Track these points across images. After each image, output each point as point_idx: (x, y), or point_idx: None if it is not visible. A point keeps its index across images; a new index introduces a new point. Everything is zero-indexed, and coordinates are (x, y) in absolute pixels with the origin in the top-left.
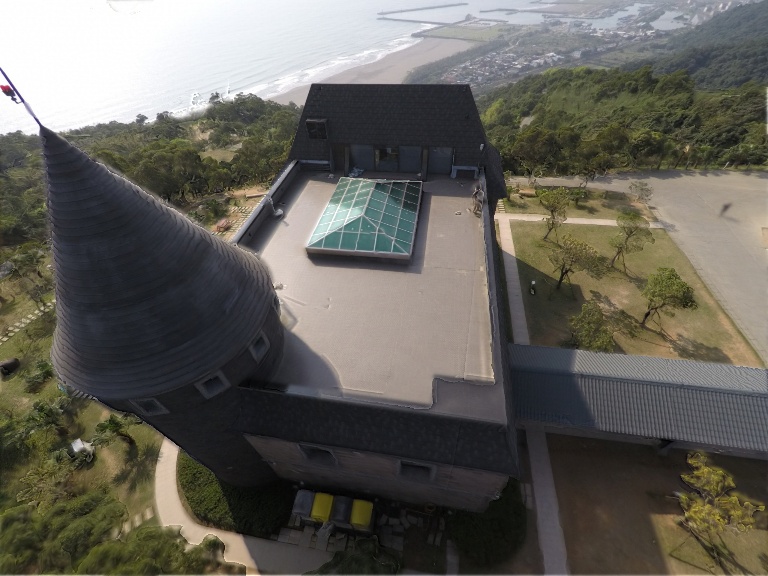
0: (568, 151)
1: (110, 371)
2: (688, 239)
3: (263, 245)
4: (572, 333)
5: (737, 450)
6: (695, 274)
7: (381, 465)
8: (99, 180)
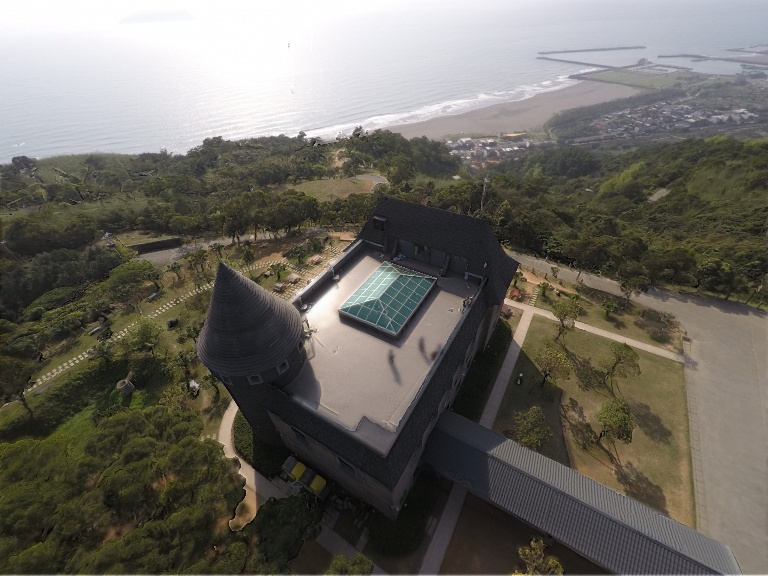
0: (629, 260)
1: (216, 359)
2: (702, 381)
3: (318, 298)
4: (514, 425)
5: (586, 557)
6: (685, 416)
7: (330, 457)
8: (234, 280)
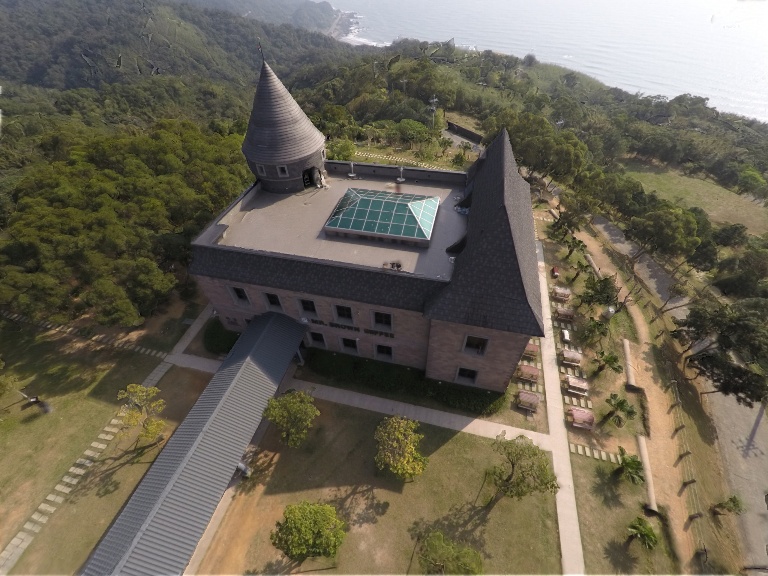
0: None
1: None
2: None
3: (367, 179)
4: None
5: None
6: None
7: None
8: (265, 80)
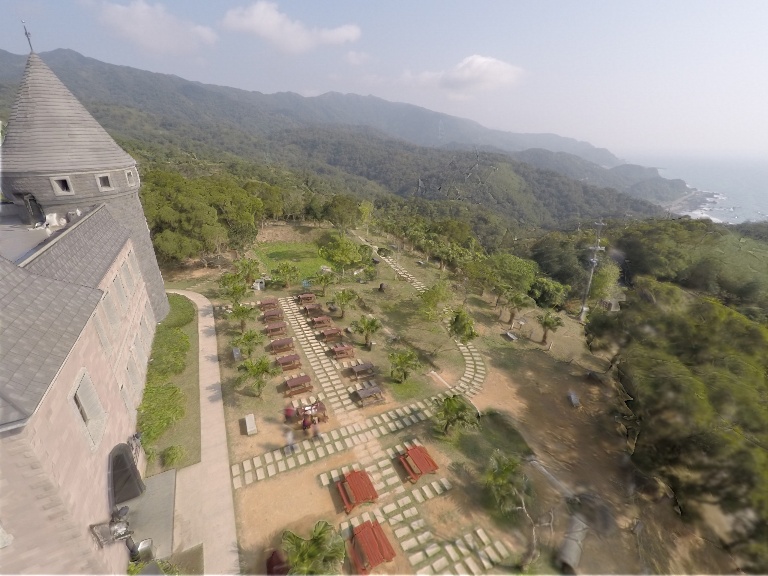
0: None
1: None
2: None
3: None
4: None
5: None
6: None
7: None
8: None
